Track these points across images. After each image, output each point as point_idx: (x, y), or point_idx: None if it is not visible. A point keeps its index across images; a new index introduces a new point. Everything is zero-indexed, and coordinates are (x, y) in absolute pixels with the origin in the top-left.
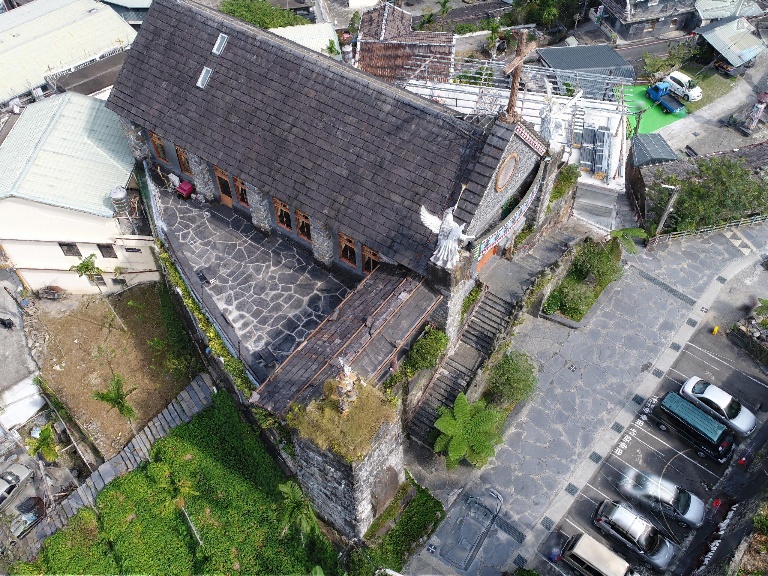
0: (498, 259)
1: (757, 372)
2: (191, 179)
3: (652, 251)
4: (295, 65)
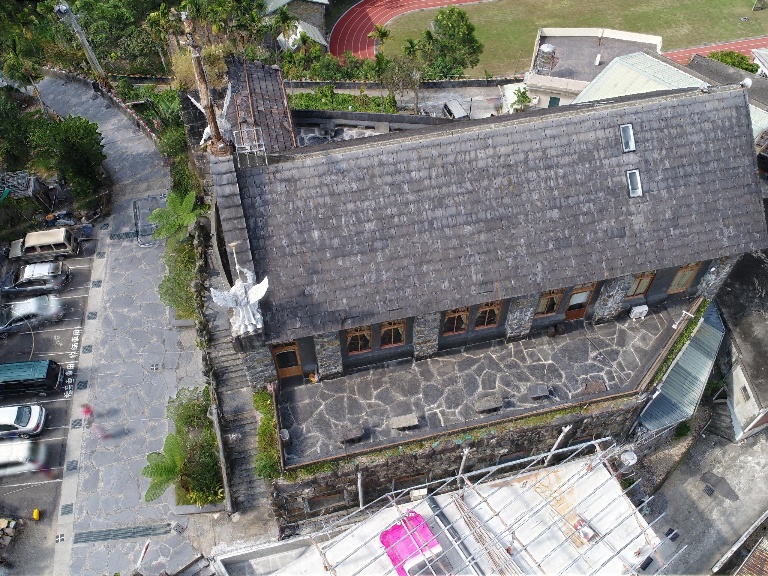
0: None
1: None
2: None
3: (159, 575)
4: None
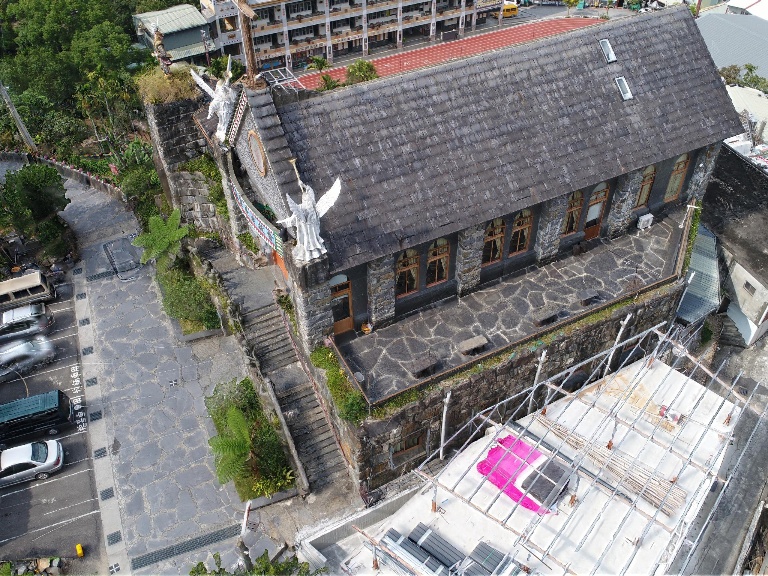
0: None
1: (1, 553)
2: None
3: None
4: None
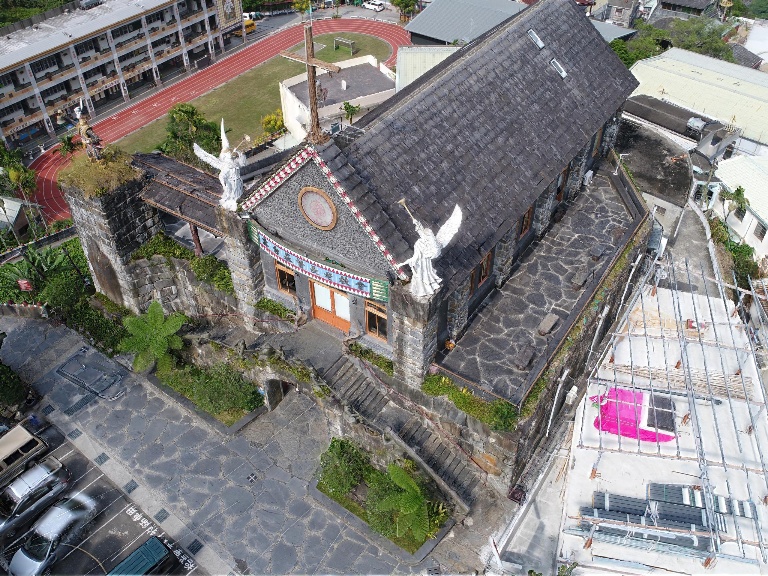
0: None
1: None
2: None
3: None
4: None
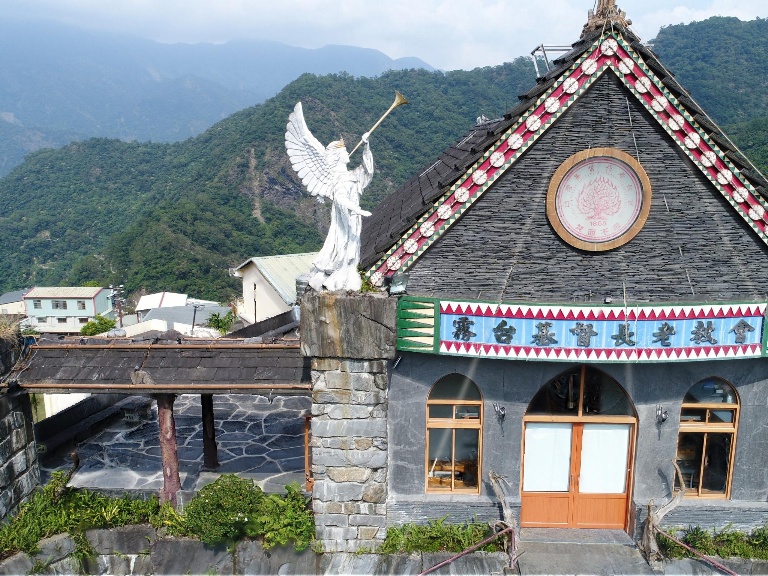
0: (624, 542)
1: None
2: None
3: None
4: None
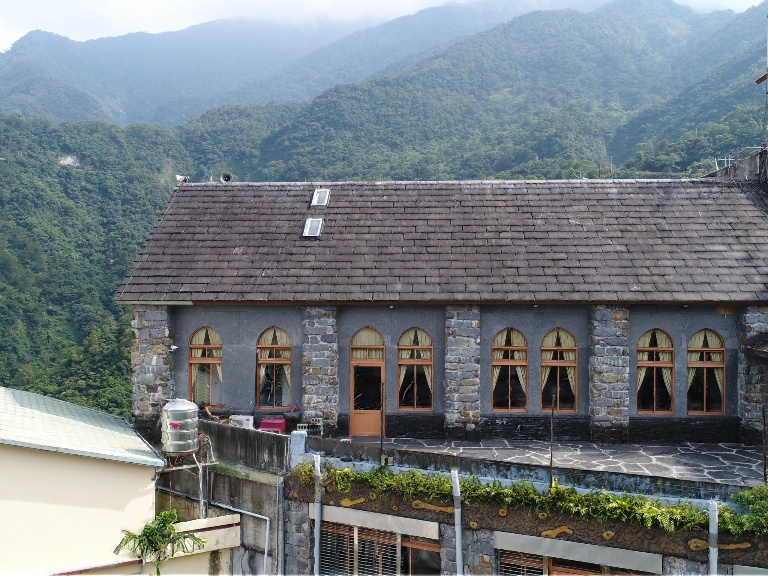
0: None
1: None
2: (280, 410)
3: None
4: (453, 190)
